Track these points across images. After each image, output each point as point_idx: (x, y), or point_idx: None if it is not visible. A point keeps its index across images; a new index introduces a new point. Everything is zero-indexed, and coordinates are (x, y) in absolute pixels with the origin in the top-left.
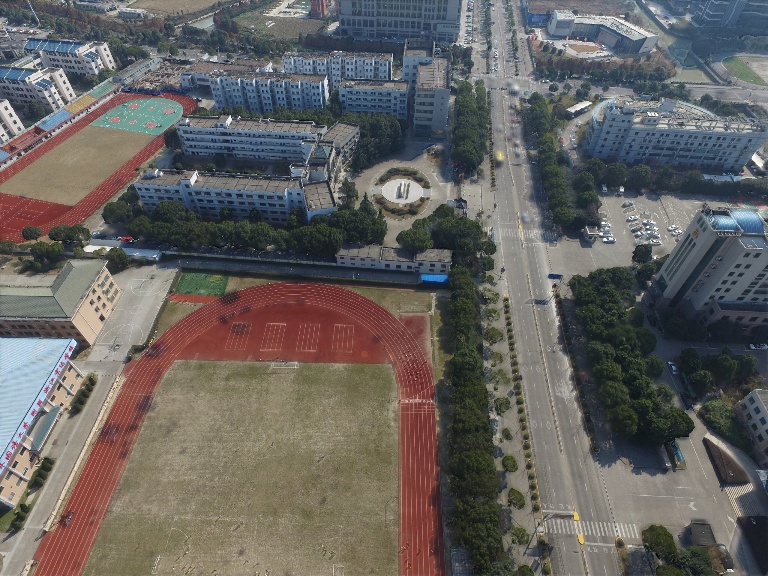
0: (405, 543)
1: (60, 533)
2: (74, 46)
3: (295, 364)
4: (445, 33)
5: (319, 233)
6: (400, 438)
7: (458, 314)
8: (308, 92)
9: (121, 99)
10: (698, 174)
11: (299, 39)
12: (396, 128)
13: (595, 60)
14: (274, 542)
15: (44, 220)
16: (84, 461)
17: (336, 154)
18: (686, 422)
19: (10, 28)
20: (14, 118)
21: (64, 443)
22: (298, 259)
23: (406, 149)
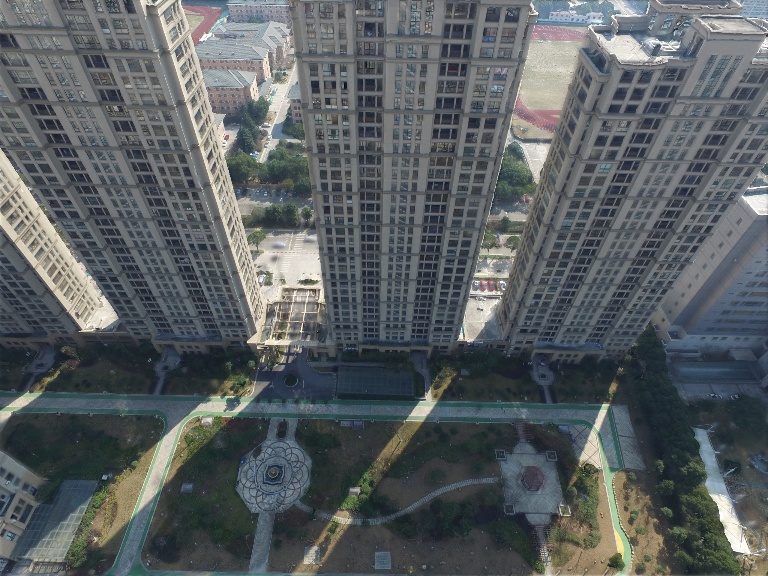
0: None
1: None
2: None
3: None
4: None
5: (543, 2)
6: None
7: None
8: None
9: None
10: None
11: None
12: None
13: None
14: None
15: None
16: None
17: None
18: None
19: None
20: None
21: None
22: None
23: None
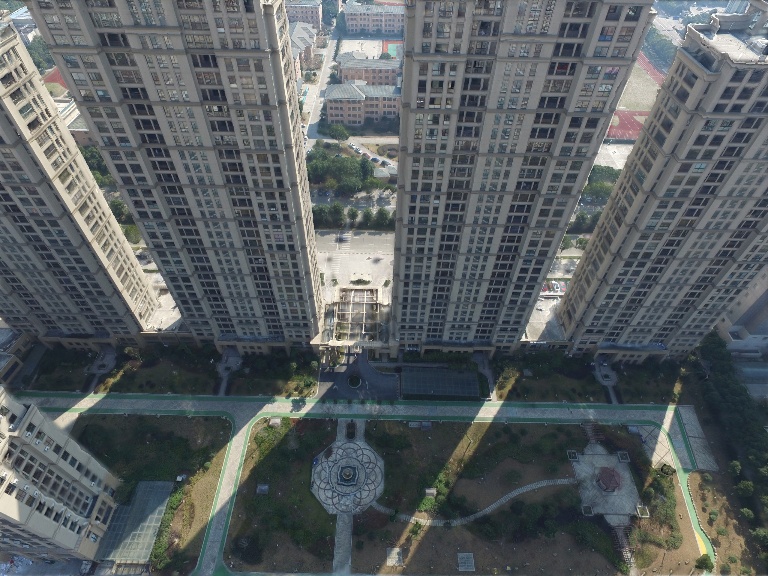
0: (645, 68)
1: None
2: None
3: None
4: None
5: None
6: None
7: None
8: None
9: None
10: None
11: None
12: None
13: None
14: None
15: None
16: None
17: None
18: None
19: None
20: None
21: None
22: None
23: None
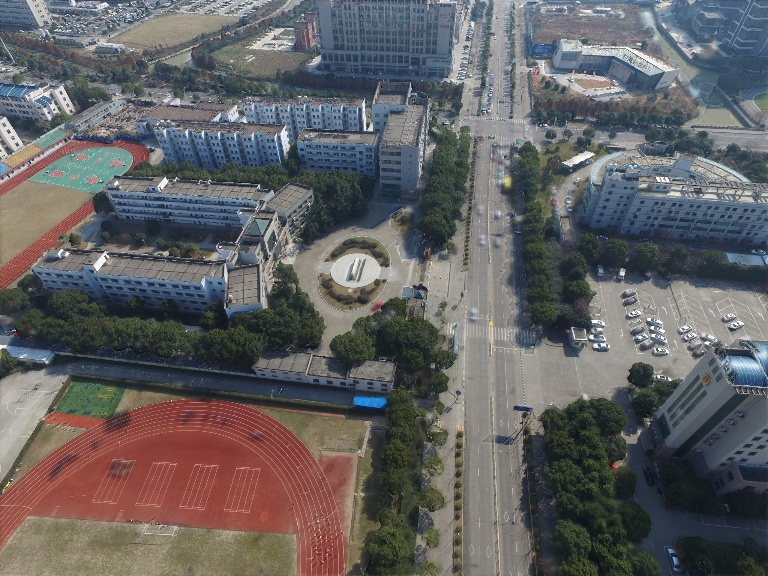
0: None
1: None
2: (27, 90)
3: (173, 529)
4: (435, 68)
5: (231, 341)
6: None
7: (388, 466)
8: (264, 145)
9: (70, 148)
10: (719, 256)
11: (277, 76)
12: (355, 191)
13: (601, 101)
14: None
15: None
16: None
17: (281, 224)
18: None
19: None
20: None
21: None
22: (210, 367)
23: (370, 213)
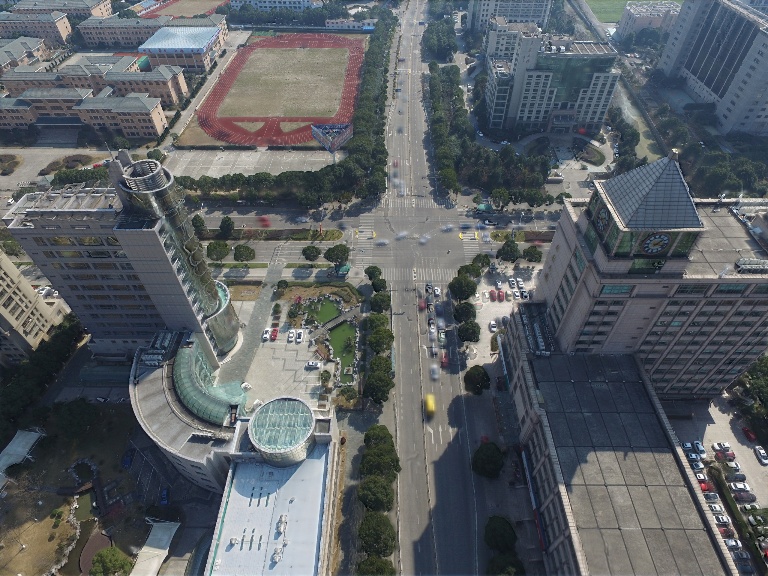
0: (347, 74)
1: (226, 74)
2: None
3: (307, 48)
4: None
5: (317, 10)
6: (349, 60)
7: None
8: None
9: None
10: None
11: None
12: None
13: None
14: (301, 74)
15: None
16: (229, 64)
17: None
18: (453, 43)
19: None
20: None
21: (219, 62)
22: (308, 26)
23: (364, 0)
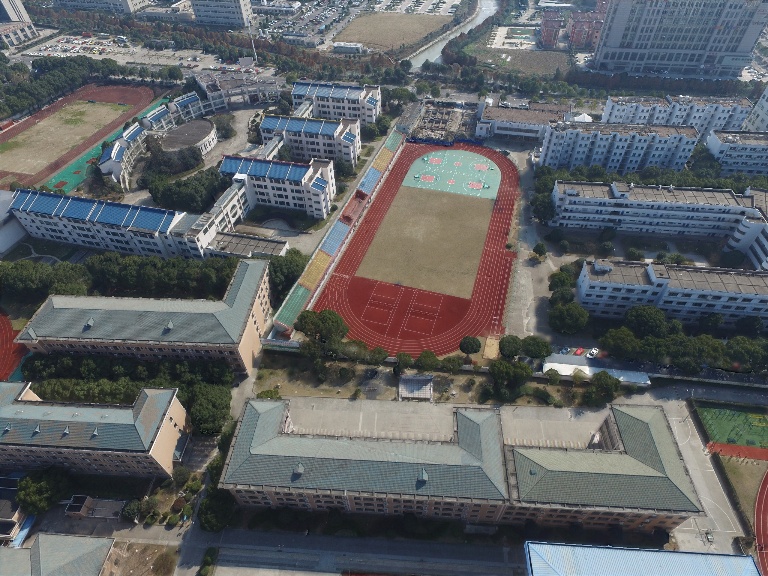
0: None
1: None
2: (350, 91)
3: None
4: (731, 66)
5: None
6: None
7: None
8: (671, 147)
9: (414, 151)
10: None
11: (556, 75)
12: None
13: None
14: None
15: (450, 320)
16: None
17: None
18: None
19: (226, 66)
20: (332, 180)
21: None
22: None
23: None
